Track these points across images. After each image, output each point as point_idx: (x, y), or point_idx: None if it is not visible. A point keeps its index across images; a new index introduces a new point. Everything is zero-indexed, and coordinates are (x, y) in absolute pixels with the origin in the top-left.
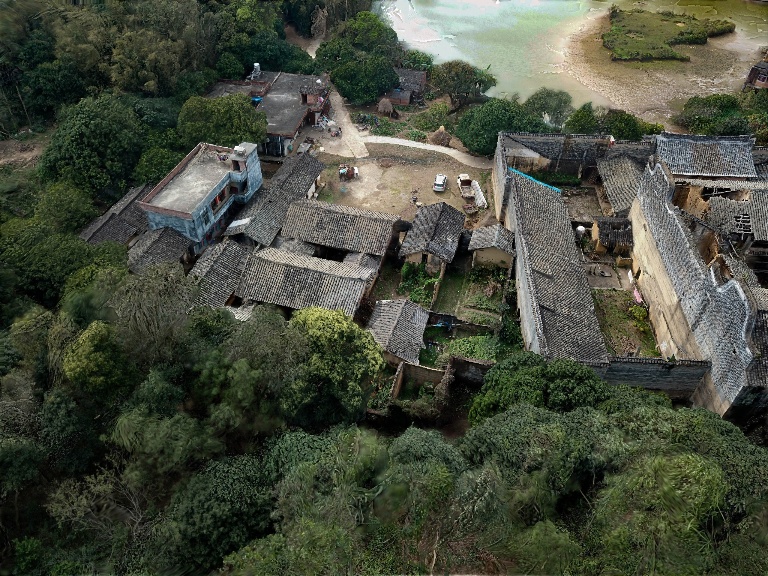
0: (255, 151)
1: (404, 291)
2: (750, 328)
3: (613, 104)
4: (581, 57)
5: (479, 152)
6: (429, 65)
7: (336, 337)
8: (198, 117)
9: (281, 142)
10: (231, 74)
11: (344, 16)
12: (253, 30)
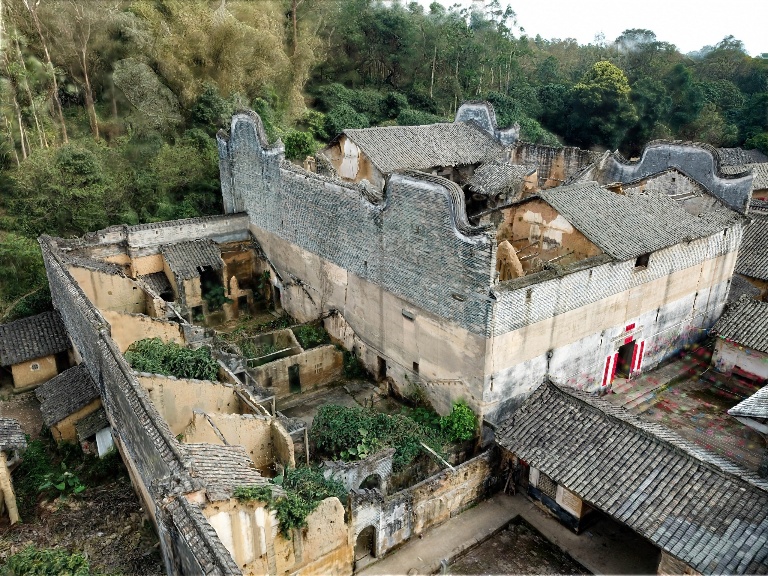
0: None
1: None
2: None
3: None
4: None
5: None
6: None
7: None
8: None
9: None
10: None
11: None
12: None
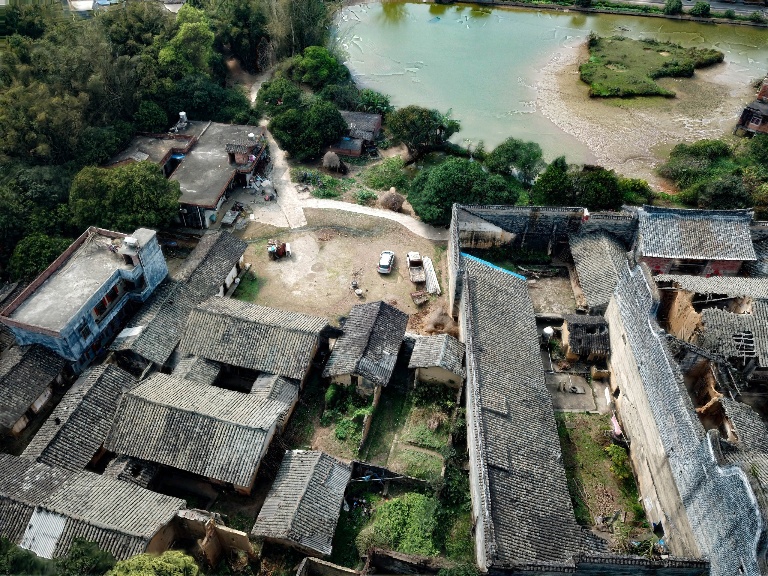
0: (153, 240)
1: (329, 422)
2: (764, 548)
3: (591, 151)
4: (556, 93)
5: (433, 223)
6: (385, 107)
7: None
8: (91, 193)
9: (201, 213)
10: (151, 126)
11: (292, 50)
12: (178, 74)
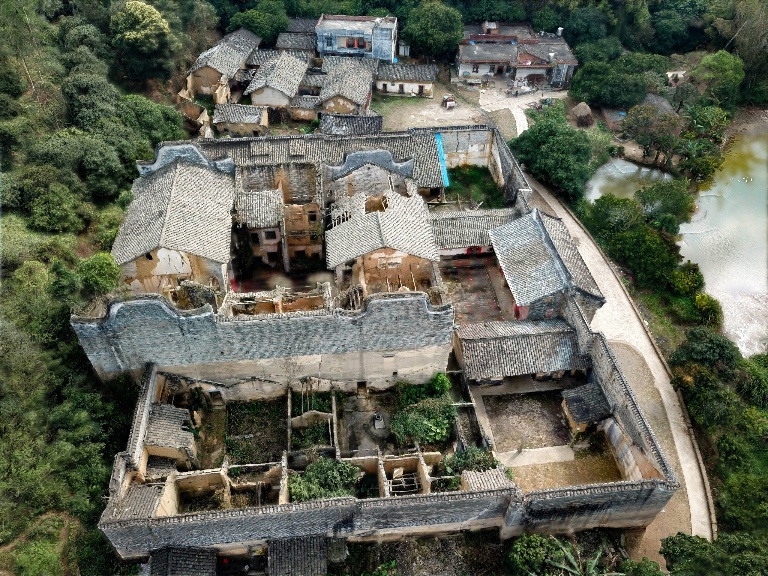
0: (388, 30)
1: None
2: None
3: None
4: None
5: None
6: (700, 125)
7: (129, 12)
8: (420, 7)
9: None
10: (536, 24)
11: None
12: (586, 4)
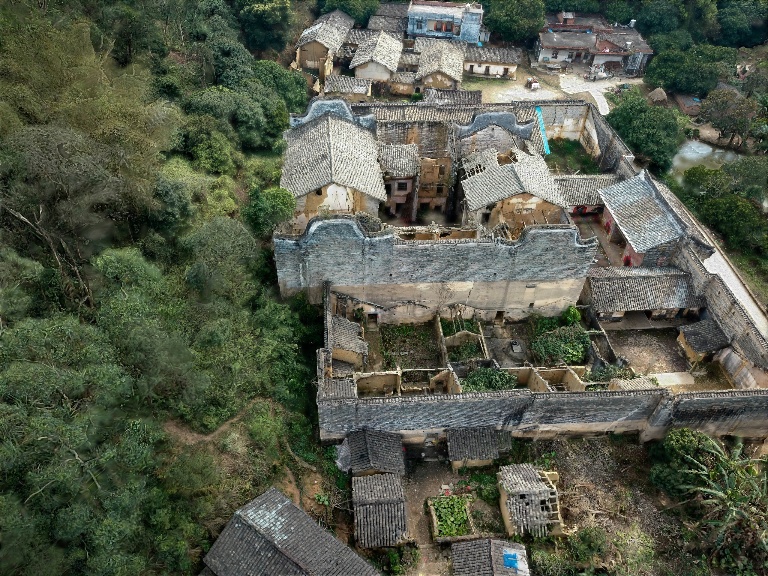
0: (478, 15)
1: None
2: None
3: None
4: None
5: None
6: None
7: None
8: None
9: (540, 49)
10: (609, 16)
11: None
12: None
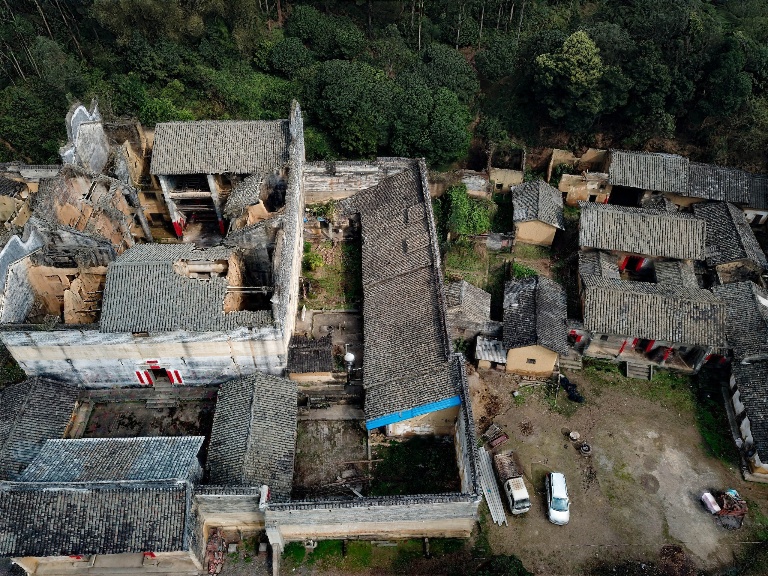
0: None
1: None
2: None
3: None
4: None
5: None
6: None
7: None
8: None
9: None
10: None
11: None
12: None
